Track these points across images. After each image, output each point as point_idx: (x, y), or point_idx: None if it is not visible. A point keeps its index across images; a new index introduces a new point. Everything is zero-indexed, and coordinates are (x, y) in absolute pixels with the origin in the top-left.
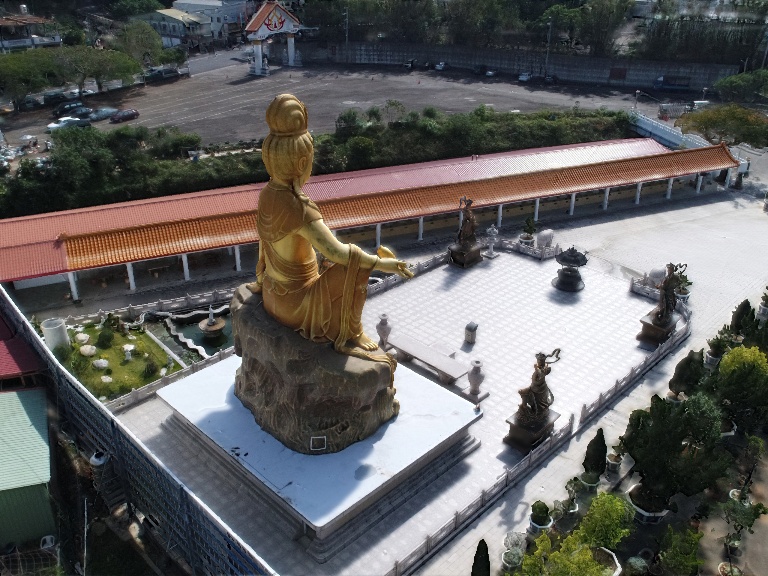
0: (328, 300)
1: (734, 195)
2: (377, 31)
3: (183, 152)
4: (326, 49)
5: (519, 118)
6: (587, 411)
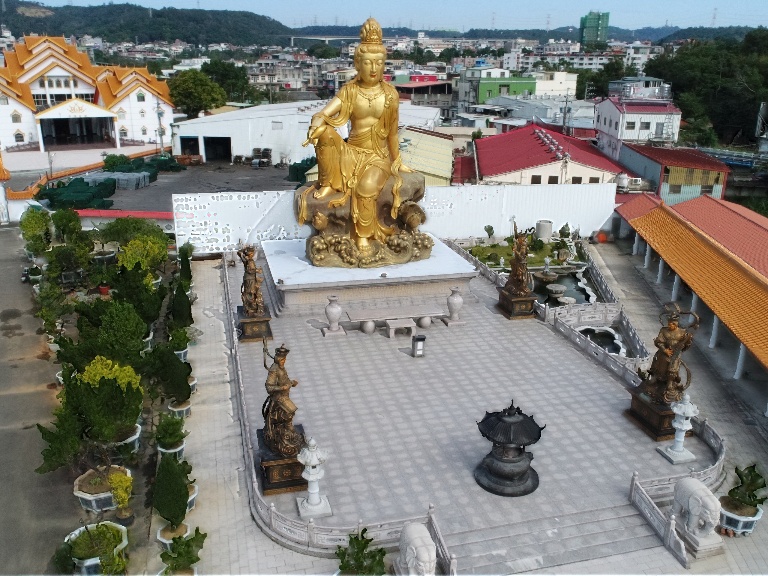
0: None
1: None
2: None
3: None
4: None
5: None
6: None
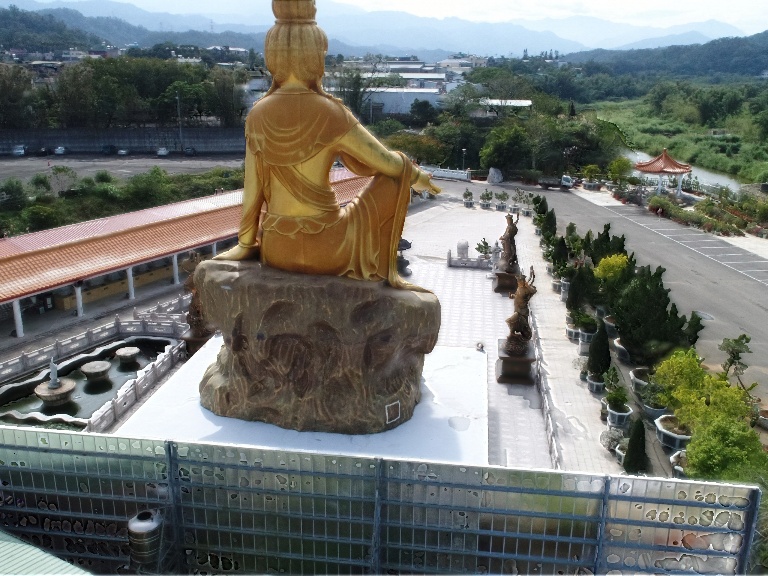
0: (377, 225)
1: (436, 202)
2: None
3: None
4: None
5: (195, 178)
6: None
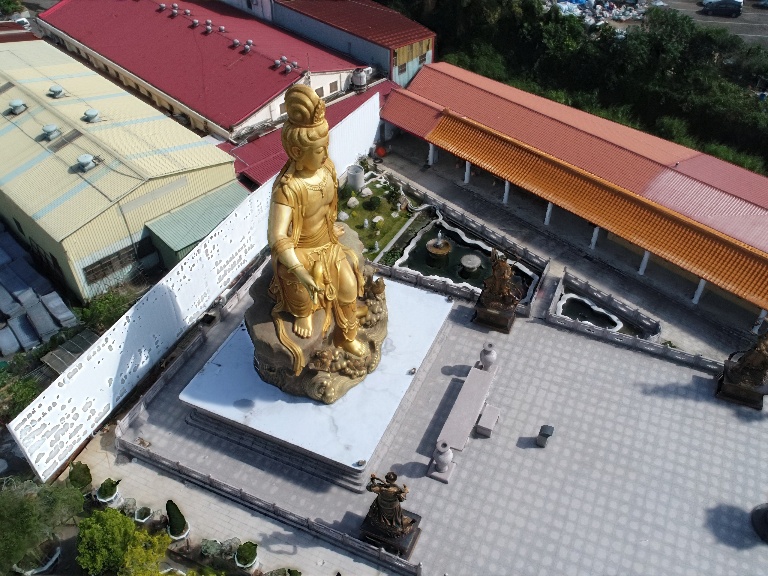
0: None
1: None
2: None
3: (763, 82)
4: None
5: None
6: None
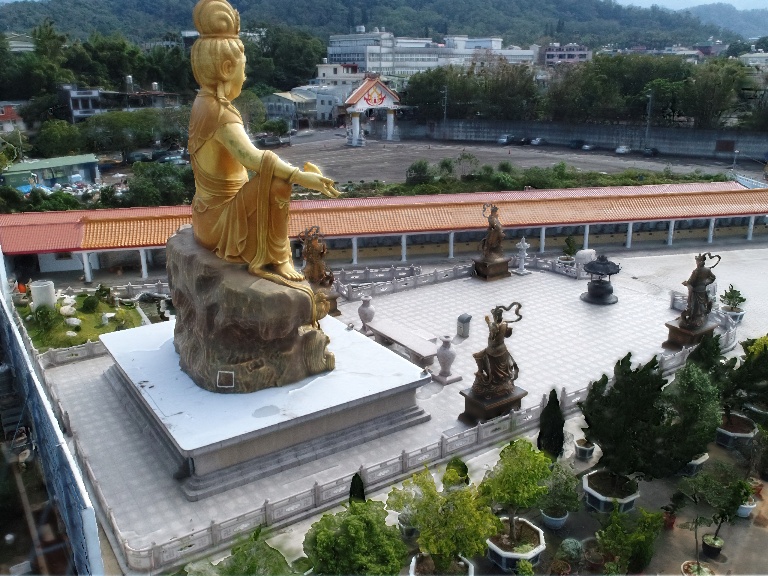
0: (244, 214)
1: None
2: (476, 110)
3: None
4: (425, 126)
5: (603, 178)
6: (569, 399)
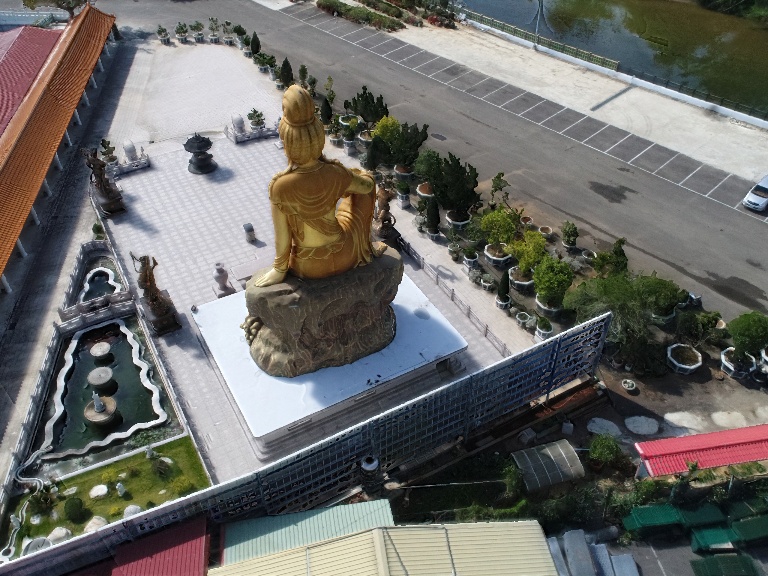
0: None
1: (130, 45)
2: None
3: None
4: None
5: None
6: None
